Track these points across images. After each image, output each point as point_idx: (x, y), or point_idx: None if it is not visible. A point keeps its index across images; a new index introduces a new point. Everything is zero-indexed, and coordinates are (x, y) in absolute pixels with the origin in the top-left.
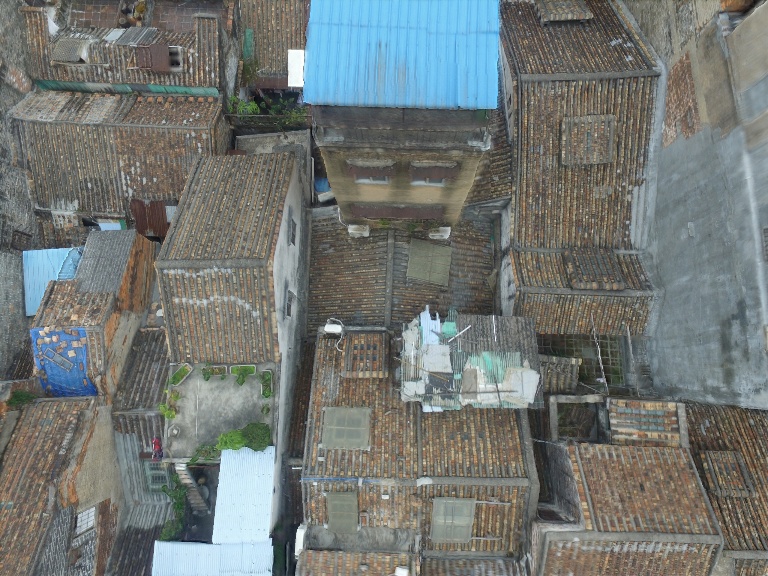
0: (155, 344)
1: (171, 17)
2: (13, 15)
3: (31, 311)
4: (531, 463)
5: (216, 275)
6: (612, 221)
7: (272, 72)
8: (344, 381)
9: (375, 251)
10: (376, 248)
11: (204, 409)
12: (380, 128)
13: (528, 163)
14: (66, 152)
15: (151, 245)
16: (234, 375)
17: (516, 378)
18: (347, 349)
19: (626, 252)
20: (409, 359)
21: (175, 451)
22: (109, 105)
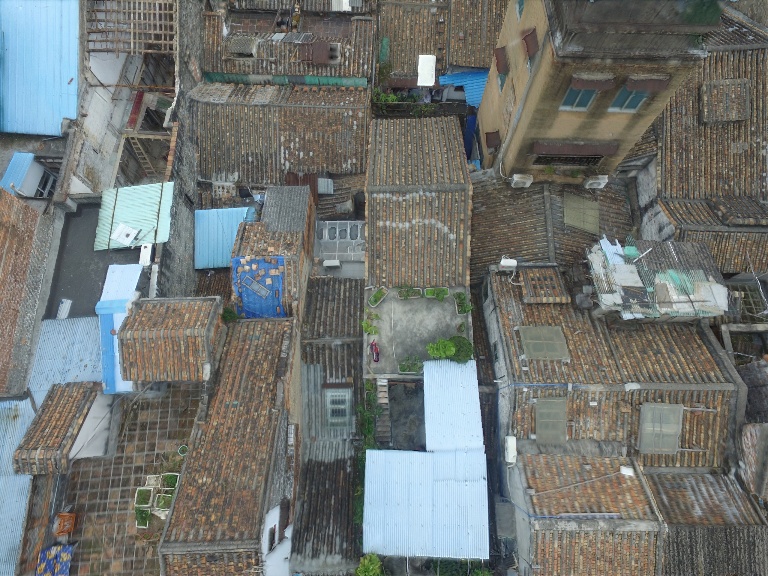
0: (327, 288)
1: (318, 28)
2: (198, 17)
3: (199, 265)
4: (732, 370)
5: (421, 199)
6: (749, 174)
7: (403, 74)
8: (526, 308)
9: (531, 204)
10: (532, 201)
11: (399, 330)
12: (626, 32)
13: (672, 122)
14: (232, 130)
15: (314, 206)
16: (428, 297)
17: (706, 290)
18: (526, 280)
19: (764, 202)
20: (600, 276)
21: (374, 368)
22: (271, 92)
